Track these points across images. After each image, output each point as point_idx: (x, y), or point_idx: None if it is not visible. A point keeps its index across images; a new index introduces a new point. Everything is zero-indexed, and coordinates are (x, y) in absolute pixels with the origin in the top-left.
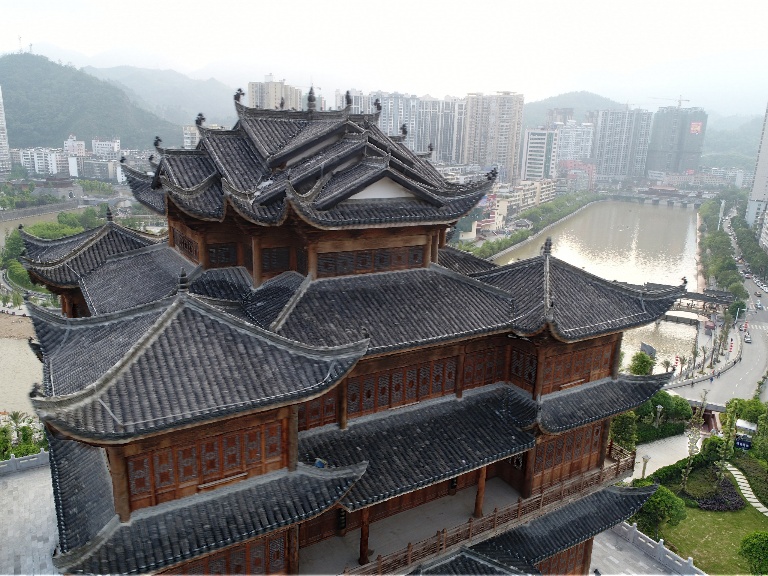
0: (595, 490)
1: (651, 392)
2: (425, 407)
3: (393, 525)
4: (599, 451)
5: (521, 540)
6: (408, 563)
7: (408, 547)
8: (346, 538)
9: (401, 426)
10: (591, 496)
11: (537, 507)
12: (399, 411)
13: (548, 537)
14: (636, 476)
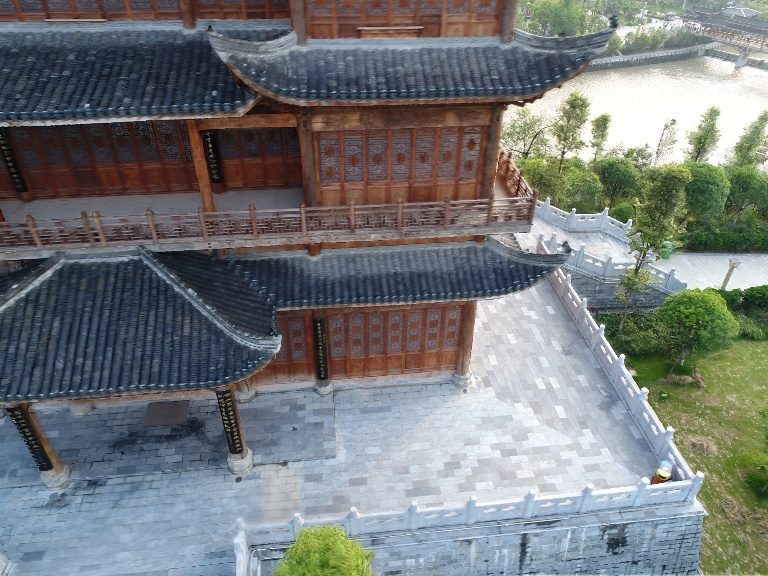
0: (434, 234)
1: (559, 71)
2: (117, 31)
3: (96, 205)
4: (479, 180)
5: (288, 274)
6: (37, 243)
7: (27, 220)
8: (26, 204)
9: (51, 47)
10: (458, 250)
11: (296, 228)
12: (67, 28)
13: (335, 282)
14: (727, 288)
